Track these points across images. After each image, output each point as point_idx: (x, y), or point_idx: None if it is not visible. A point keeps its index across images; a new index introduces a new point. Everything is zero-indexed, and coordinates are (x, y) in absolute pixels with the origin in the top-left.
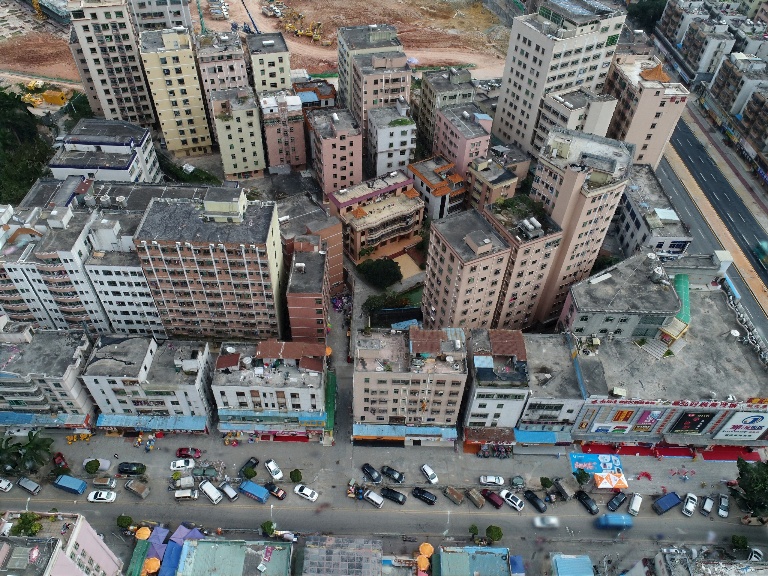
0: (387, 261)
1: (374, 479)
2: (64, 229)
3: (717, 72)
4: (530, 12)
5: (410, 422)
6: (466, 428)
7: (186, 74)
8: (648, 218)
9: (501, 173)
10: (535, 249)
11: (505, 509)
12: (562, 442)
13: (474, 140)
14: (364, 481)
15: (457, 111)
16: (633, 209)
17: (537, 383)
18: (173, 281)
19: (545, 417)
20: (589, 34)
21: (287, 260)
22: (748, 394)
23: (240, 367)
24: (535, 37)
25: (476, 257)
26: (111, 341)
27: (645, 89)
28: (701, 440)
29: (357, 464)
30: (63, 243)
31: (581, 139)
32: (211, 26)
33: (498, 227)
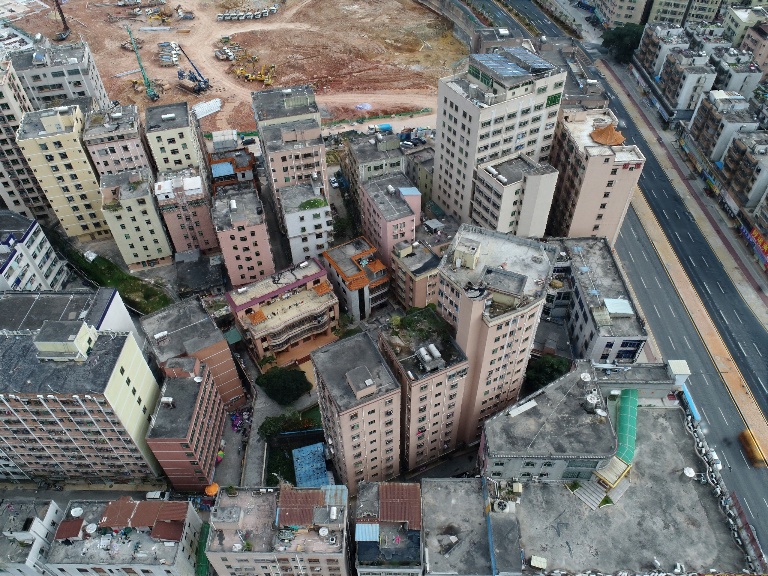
0: (289, 373)
1: None
2: None
3: (696, 111)
4: None
5: None
6: None
7: (73, 158)
8: (595, 313)
9: (427, 259)
10: (435, 383)
11: None
12: None
13: (396, 221)
14: None
15: (383, 184)
16: (581, 298)
17: (439, 550)
18: (11, 429)
19: None
20: (523, 97)
21: None
22: (702, 560)
23: (84, 536)
24: (461, 102)
25: (356, 402)
26: None
27: (591, 157)
28: None
29: None
30: None
31: (496, 239)
32: (159, 74)
33: (391, 355)
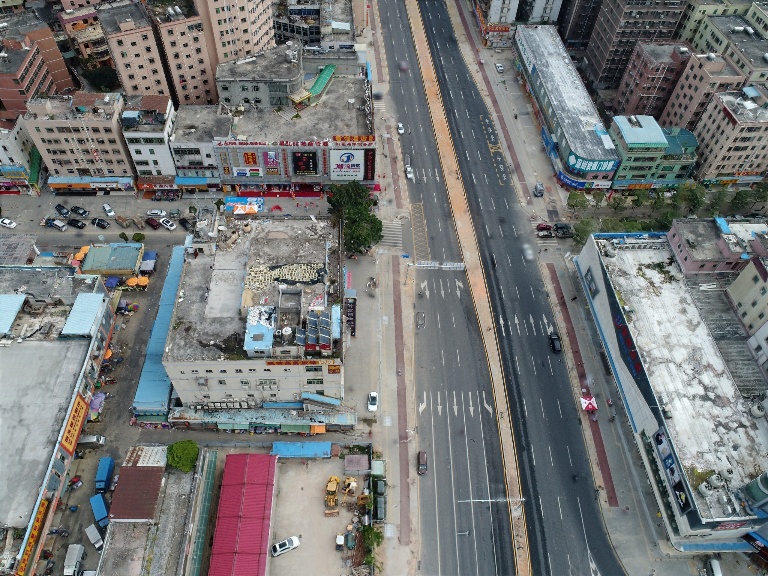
0: None
1: (63, 213)
2: None
3: None
4: None
5: (96, 174)
6: (138, 176)
7: None
8: (323, 28)
9: None
10: (179, 31)
11: (161, 230)
12: (211, 184)
13: None
14: (56, 216)
15: None
16: None
17: (182, 135)
18: None
19: (193, 163)
20: None
21: None
22: None
23: None
24: None
25: None
26: None
27: None
28: (318, 179)
29: (54, 207)
30: None
31: None
32: None
33: None
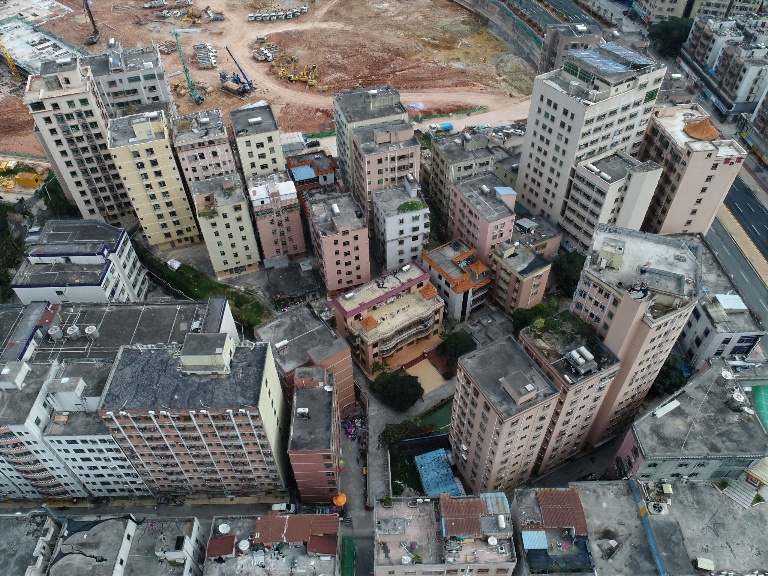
0: (405, 379)
1: None
2: (18, 390)
3: (760, 104)
4: (548, 57)
5: None
6: None
7: (163, 165)
8: (710, 309)
9: (531, 259)
10: (587, 386)
11: None
12: None
13: (497, 222)
14: None
15: (474, 184)
16: None
17: (601, 555)
18: (151, 446)
19: None
20: (625, 93)
21: (288, 391)
22: None
23: (236, 553)
24: (562, 100)
25: (517, 408)
26: (80, 527)
27: (694, 152)
28: None
29: None
30: (17, 410)
31: (632, 238)
32: (199, 77)
33: (540, 359)
